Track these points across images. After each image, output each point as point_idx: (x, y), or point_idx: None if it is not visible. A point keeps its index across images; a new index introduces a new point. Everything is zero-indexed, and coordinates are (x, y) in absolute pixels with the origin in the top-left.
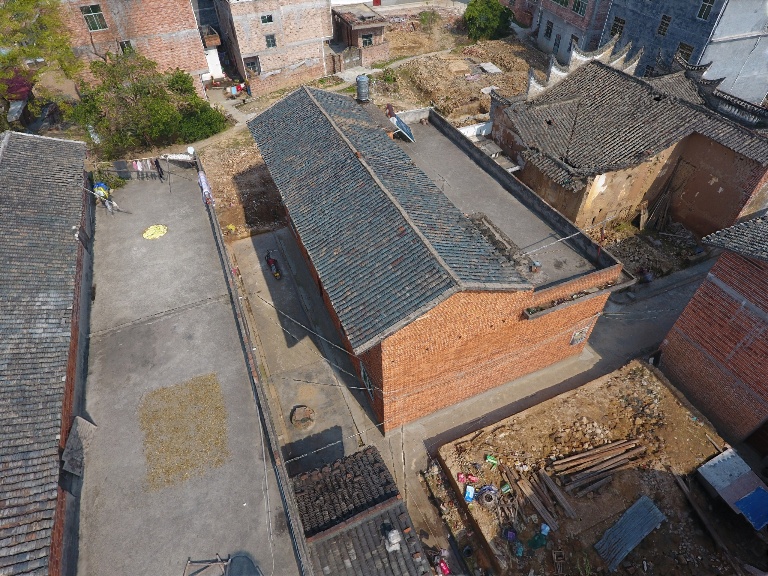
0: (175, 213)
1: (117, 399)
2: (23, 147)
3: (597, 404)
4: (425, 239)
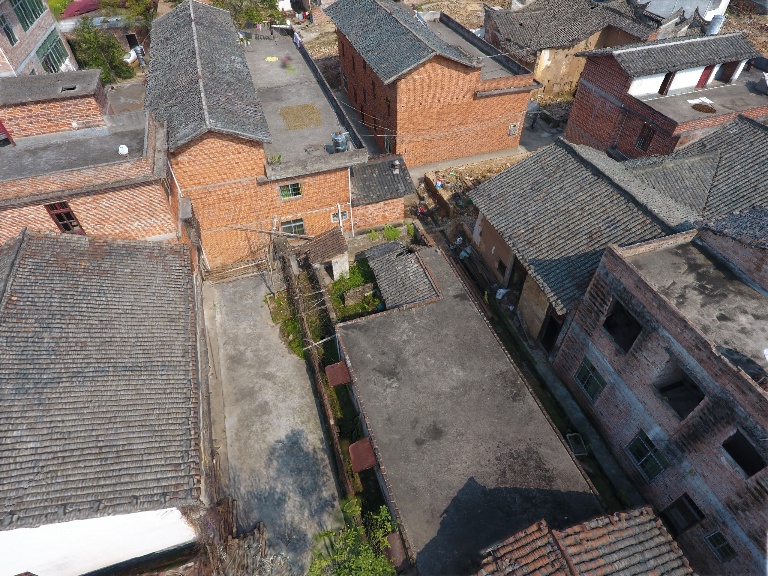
0: (281, 53)
1: (267, 108)
2: (200, 7)
3: (518, 160)
4: (423, 40)
